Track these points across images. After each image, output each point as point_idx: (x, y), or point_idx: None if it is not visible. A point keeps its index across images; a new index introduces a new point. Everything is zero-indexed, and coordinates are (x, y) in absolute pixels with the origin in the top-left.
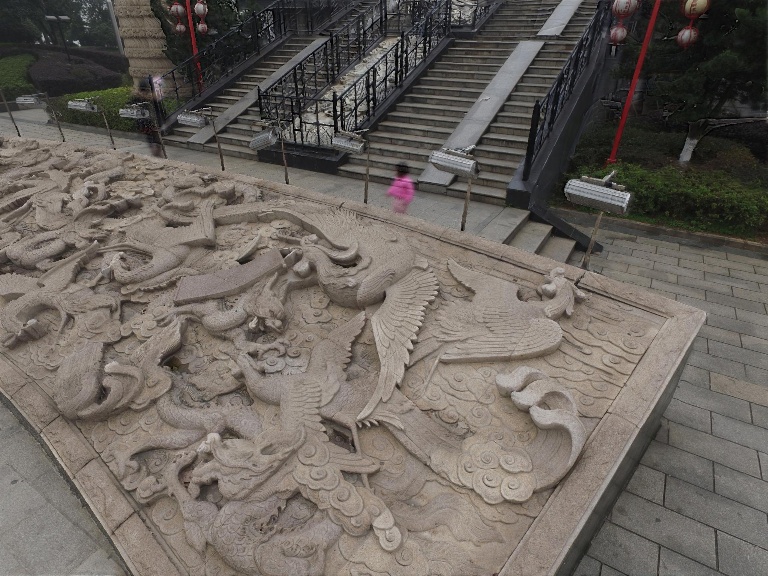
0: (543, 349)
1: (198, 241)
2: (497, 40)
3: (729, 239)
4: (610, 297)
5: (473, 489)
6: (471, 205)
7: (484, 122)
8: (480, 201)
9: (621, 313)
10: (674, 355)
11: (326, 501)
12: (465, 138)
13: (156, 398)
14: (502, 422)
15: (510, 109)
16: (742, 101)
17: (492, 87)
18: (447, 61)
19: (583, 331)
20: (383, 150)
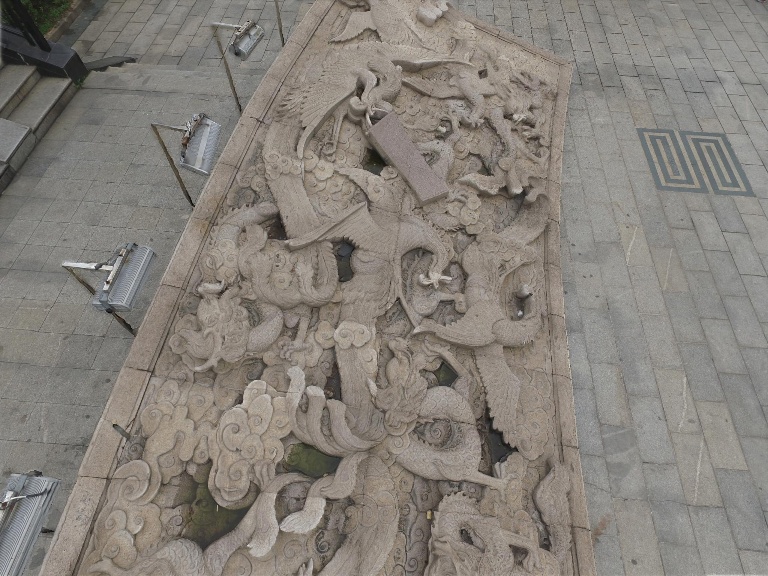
0: None
1: None
2: None
3: None
4: None
5: None
6: (80, 113)
7: None
8: (63, 108)
9: None
10: None
11: None
12: None
13: None
14: None
15: None
16: None
17: None
18: None
19: None
20: None
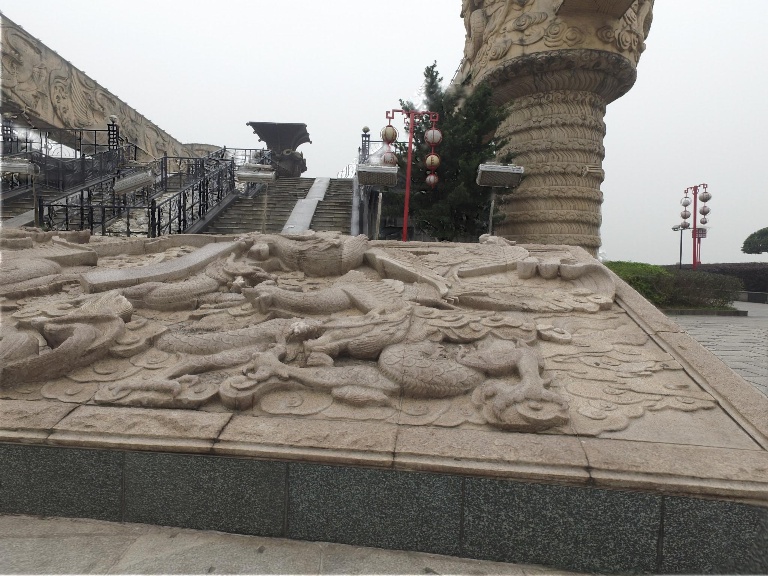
0: (524, 258)
1: (75, 256)
2: None
3: None
4: None
5: (574, 309)
6: None
7: None
8: None
9: None
10: None
11: (483, 327)
12: None
13: (155, 335)
14: (543, 287)
15: None
16: (465, 230)
17: (292, 221)
18: None
19: None
20: None
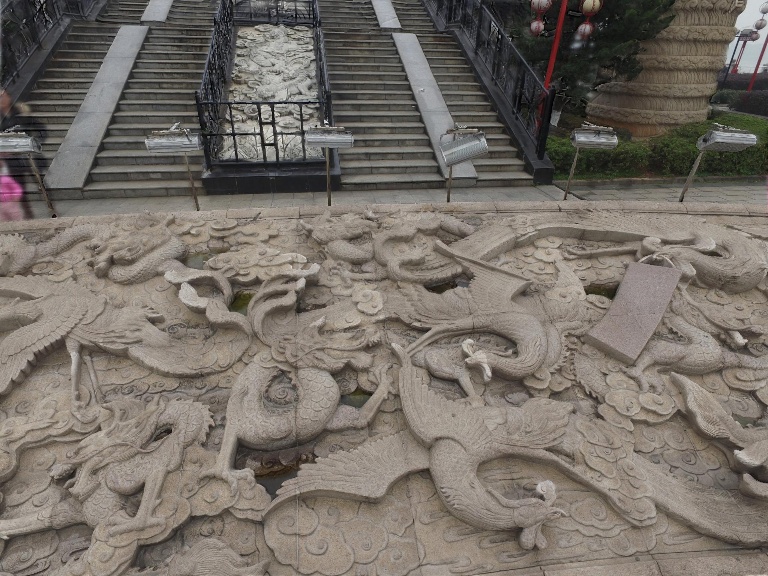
0: None
1: (519, 289)
2: None
3: (633, 179)
4: None
5: None
6: (512, 191)
7: (445, 112)
8: (510, 186)
9: None
10: None
11: None
12: (445, 130)
13: None
14: None
15: (447, 98)
16: None
17: (415, 78)
18: (332, 53)
19: None
20: (370, 154)
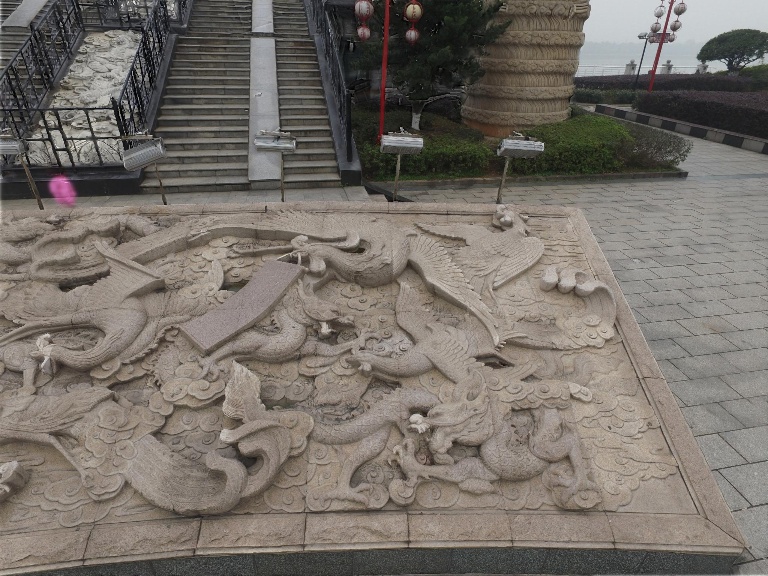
0: (541, 255)
1: (146, 287)
2: (213, 36)
3: (475, 179)
4: (532, 216)
5: (588, 345)
6: (315, 192)
7: (273, 116)
8: (318, 187)
9: (545, 223)
10: (591, 234)
11: (537, 400)
12: None
13: (311, 432)
14: (561, 305)
15: (285, 102)
16: (440, 83)
17: (256, 83)
18: (183, 58)
19: (541, 239)
20: (183, 157)
